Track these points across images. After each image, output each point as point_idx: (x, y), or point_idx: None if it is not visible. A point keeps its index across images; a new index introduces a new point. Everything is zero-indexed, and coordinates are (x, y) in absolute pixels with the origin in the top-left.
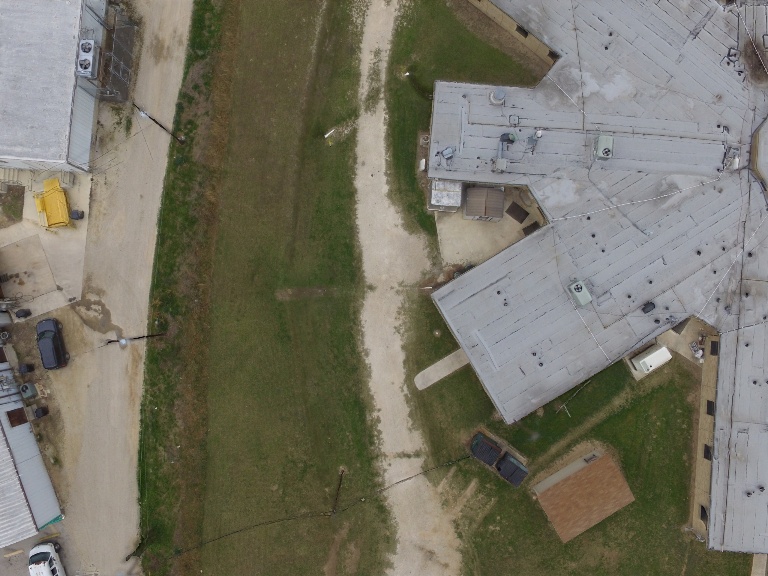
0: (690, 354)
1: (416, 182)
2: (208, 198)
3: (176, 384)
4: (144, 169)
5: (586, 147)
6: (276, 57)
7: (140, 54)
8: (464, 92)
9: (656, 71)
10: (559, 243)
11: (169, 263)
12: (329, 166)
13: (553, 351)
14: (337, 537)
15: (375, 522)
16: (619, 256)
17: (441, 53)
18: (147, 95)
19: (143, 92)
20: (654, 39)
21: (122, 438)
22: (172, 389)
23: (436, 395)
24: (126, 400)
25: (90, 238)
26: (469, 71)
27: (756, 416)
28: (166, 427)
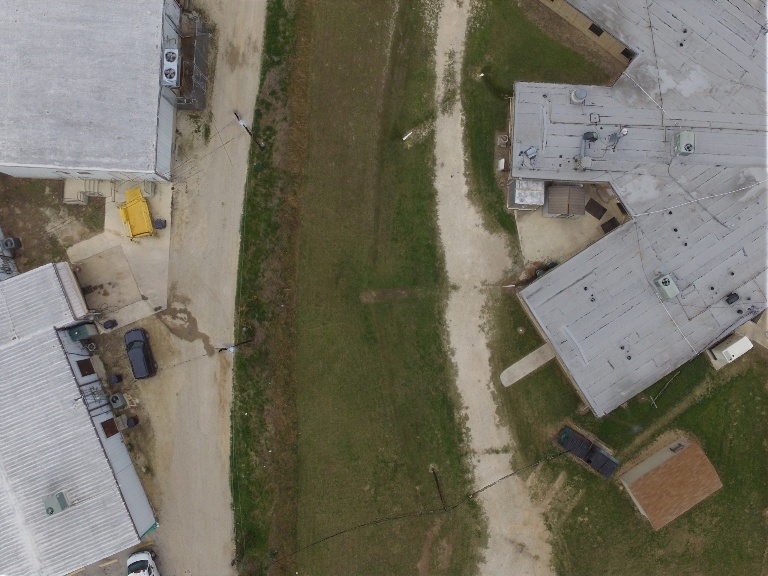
0: (767, 342)
1: (495, 182)
2: (290, 204)
3: (265, 389)
4: (225, 177)
5: (666, 143)
6: (351, 61)
7: (215, 61)
8: (544, 92)
9: (730, 66)
10: (642, 238)
11: (253, 269)
12: (408, 168)
13: (640, 344)
14: (429, 534)
15: (466, 518)
16: (701, 249)
17: (515, 53)
18: (224, 102)
19: (220, 100)
20: (728, 35)
21: (213, 445)
22: (261, 394)
23: (522, 391)
24: (216, 407)
25: (173, 247)
26: (543, 70)
27: None
28: (257, 432)
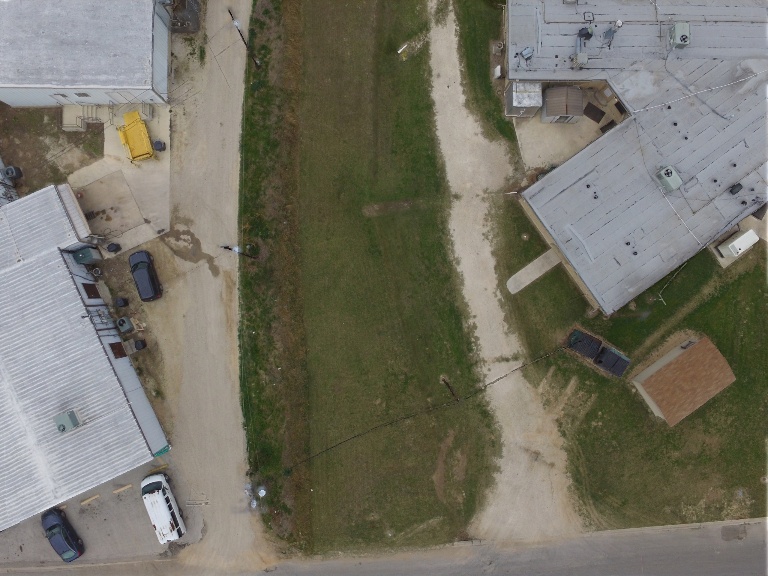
0: None
1: (492, 90)
2: (288, 120)
3: (271, 307)
4: (222, 97)
5: (661, 38)
6: None
7: None
8: None
9: None
10: (642, 134)
11: (255, 188)
12: (405, 81)
13: (646, 240)
14: (442, 446)
15: (479, 427)
16: (702, 142)
17: None
18: (218, 24)
19: (214, 21)
20: None
21: (222, 365)
22: (268, 312)
23: (529, 297)
24: (223, 327)
25: (174, 169)
26: None
27: None
28: (265, 350)
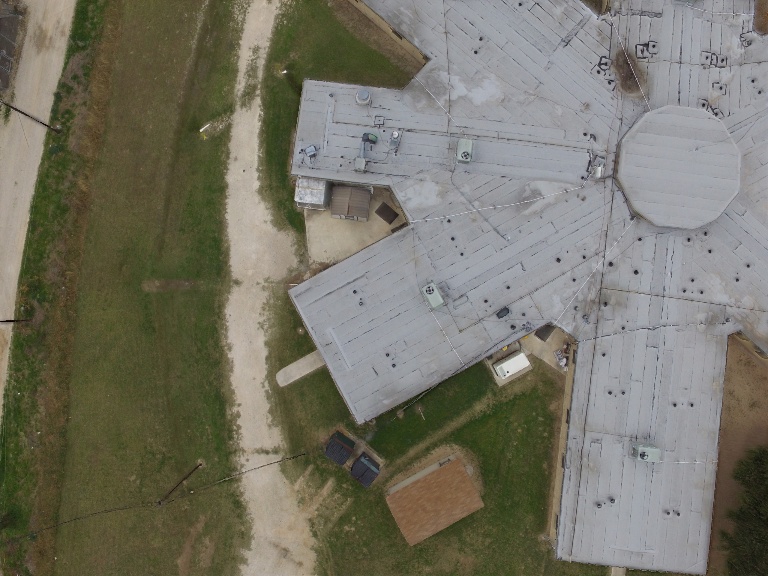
0: (555, 362)
1: (287, 179)
2: (80, 187)
3: (40, 370)
4: (20, 156)
5: (449, 150)
6: (156, 51)
7: (23, 43)
8: (331, 91)
9: (525, 77)
10: (418, 245)
11: (39, 250)
12: (202, 160)
13: (407, 352)
14: (193, 530)
15: (230, 517)
16: (477, 260)
17: (319, 52)
18: (27, 84)
19: (23, 80)
20: (524, 45)
21: None
22: (36, 375)
23: (297, 392)
24: None
25: None
26: (346, 71)
27: (610, 427)
28: (28, 413)
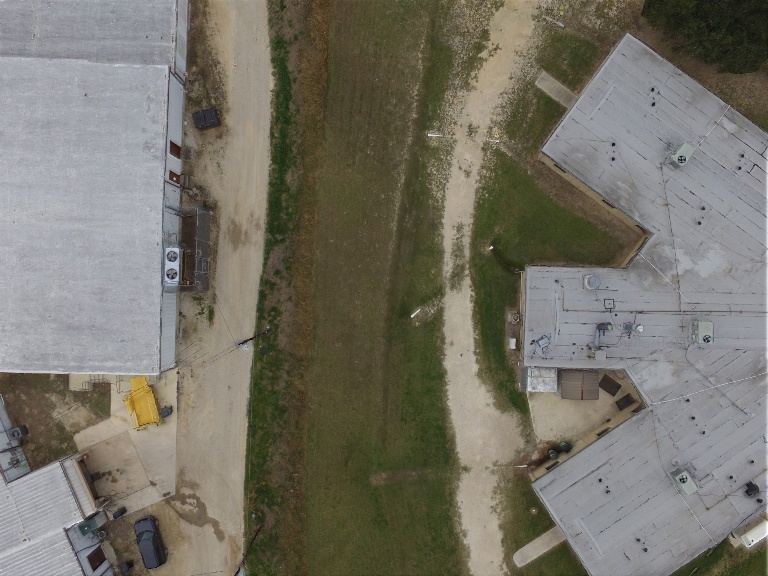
0: None
1: (506, 359)
2: (297, 387)
3: (276, 573)
4: (230, 360)
5: (683, 328)
6: (357, 237)
7: (218, 241)
8: (556, 276)
9: (751, 244)
10: (659, 426)
11: (262, 454)
12: (417, 347)
13: (657, 535)
14: None
15: None
16: (720, 437)
17: (525, 225)
18: (228, 283)
19: (224, 280)
20: (749, 212)
21: None
22: None
23: (535, 571)
24: None
25: (180, 432)
26: (555, 242)
27: None
28: None
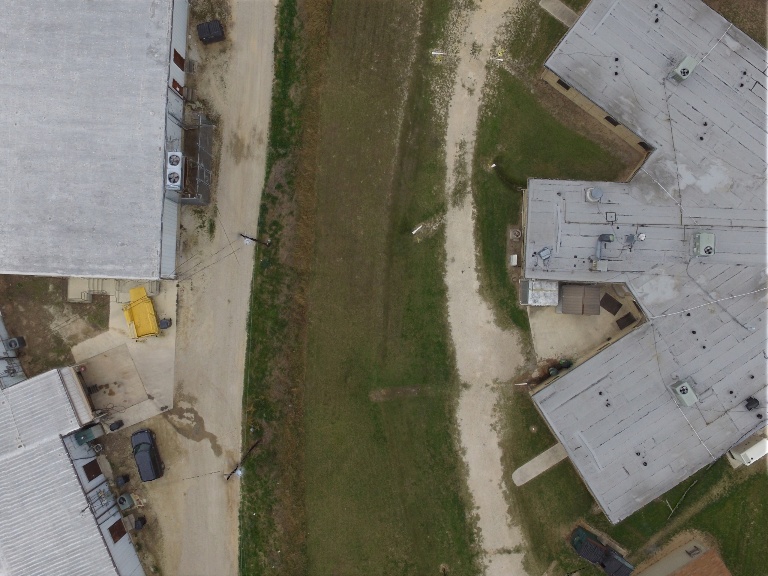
0: None
1: (507, 277)
2: (297, 301)
3: (273, 489)
4: (230, 273)
5: (685, 242)
6: (359, 152)
7: (220, 154)
8: (559, 189)
9: (752, 160)
10: (659, 340)
11: (261, 368)
12: (418, 263)
13: (656, 449)
14: None
15: None
16: (720, 352)
17: (528, 143)
18: (230, 197)
19: (225, 194)
20: (750, 128)
21: (221, 545)
22: (269, 494)
23: (534, 491)
24: (224, 507)
25: (179, 346)
26: (557, 160)
27: None
28: (265, 533)
